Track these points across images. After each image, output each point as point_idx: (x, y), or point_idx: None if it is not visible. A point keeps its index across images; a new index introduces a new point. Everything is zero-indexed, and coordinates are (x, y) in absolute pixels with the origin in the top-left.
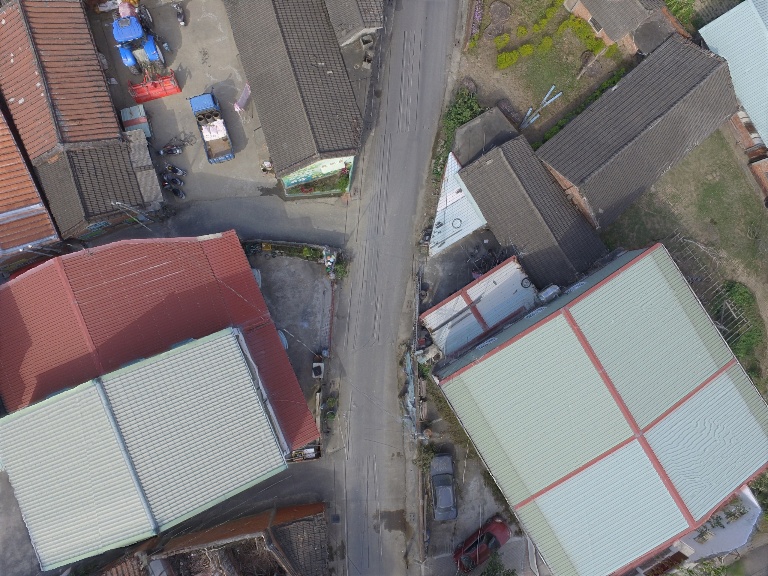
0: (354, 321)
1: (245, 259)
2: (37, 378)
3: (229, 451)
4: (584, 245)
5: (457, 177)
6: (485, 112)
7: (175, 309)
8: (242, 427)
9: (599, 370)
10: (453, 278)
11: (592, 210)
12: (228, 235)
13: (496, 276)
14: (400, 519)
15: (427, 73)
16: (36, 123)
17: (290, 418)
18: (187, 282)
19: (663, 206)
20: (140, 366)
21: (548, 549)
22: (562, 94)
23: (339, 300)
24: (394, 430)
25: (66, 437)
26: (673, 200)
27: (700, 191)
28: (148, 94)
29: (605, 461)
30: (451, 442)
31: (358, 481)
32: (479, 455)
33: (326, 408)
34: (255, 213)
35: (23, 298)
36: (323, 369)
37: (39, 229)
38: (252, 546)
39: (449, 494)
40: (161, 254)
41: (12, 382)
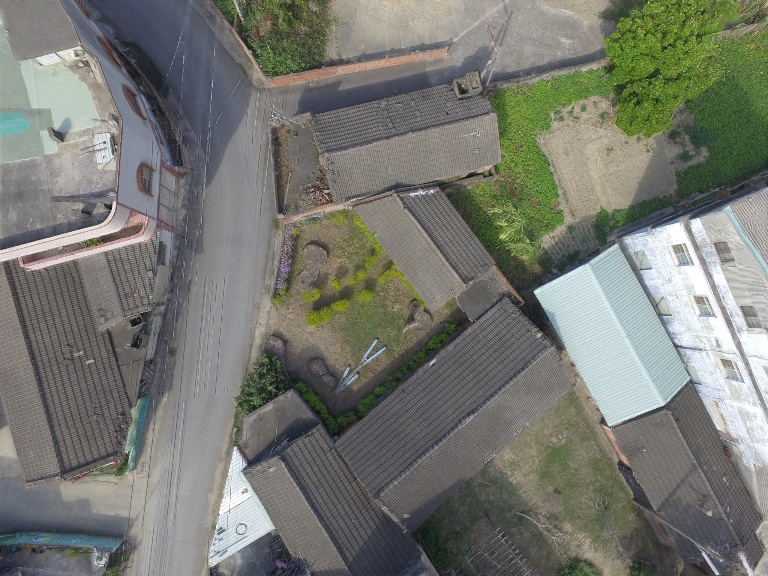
0: None
1: None
2: None
3: None
4: (387, 555)
5: (242, 476)
6: (278, 397)
7: None
8: None
9: None
10: (254, 566)
11: (395, 517)
12: None
13: None
14: None
15: (230, 327)
16: None
17: None
18: None
19: (499, 475)
20: None
21: None
22: (386, 349)
23: None
24: None
25: None
26: (511, 468)
27: (543, 456)
28: None
29: None
30: None
31: None
32: None
33: None
34: (24, 497)
35: None
36: None
37: None
38: None
39: None
40: None
41: None
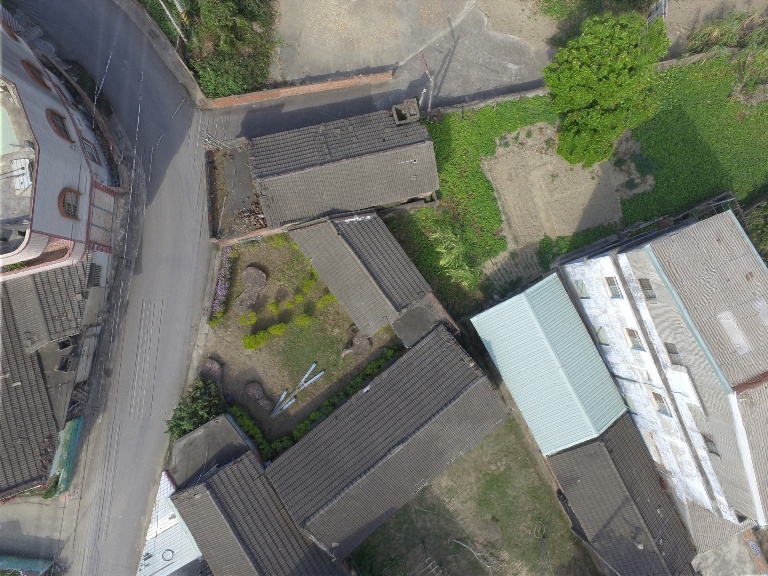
0: None
1: None
2: None
3: None
4: None
5: (169, 502)
6: (209, 422)
7: None
8: None
9: None
10: None
11: (323, 545)
12: None
13: None
14: None
15: (167, 348)
16: None
17: None
18: None
19: (437, 502)
20: None
21: None
22: (324, 373)
23: None
24: None
25: None
26: (449, 495)
27: (481, 483)
28: None
29: None
30: None
31: None
32: None
33: None
34: None
35: None
36: None
37: None
38: None
39: None
40: None
41: None
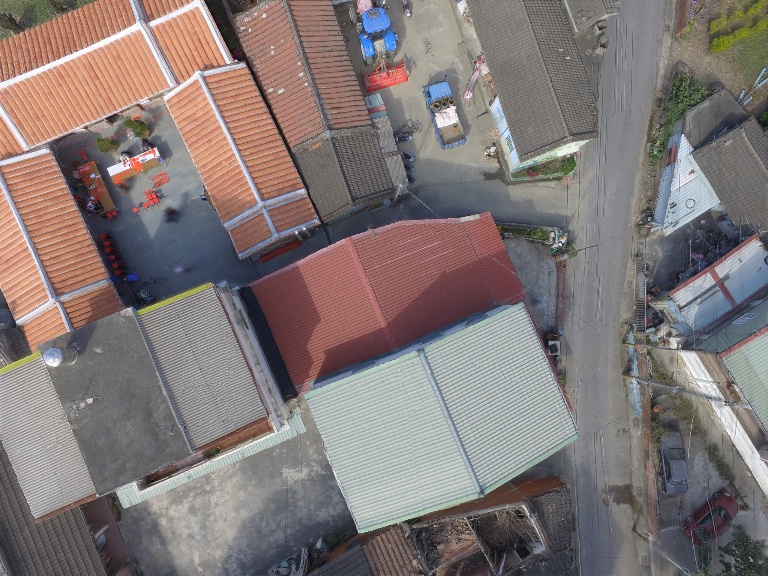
0: (578, 301)
1: (501, 239)
2: (325, 353)
3: (531, 420)
4: None
5: (690, 158)
6: (714, 94)
7: (448, 287)
8: (540, 397)
9: None
10: (672, 258)
11: None
12: (485, 216)
13: (741, 254)
14: (627, 493)
15: (640, 58)
16: (298, 112)
17: None
18: (455, 261)
19: None
20: (453, 338)
21: None
22: None
23: (563, 280)
24: (619, 406)
25: (386, 406)
26: None
27: None
28: (380, 83)
29: None
30: (675, 418)
31: (586, 456)
32: (760, 425)
33: None
34: (480, 197)
35: (313, 277)
36: (560, 346)
37: (304, 213)
38: (492, 517)
39: (683, 468)
40: (432, 234)
41: (299, 357)
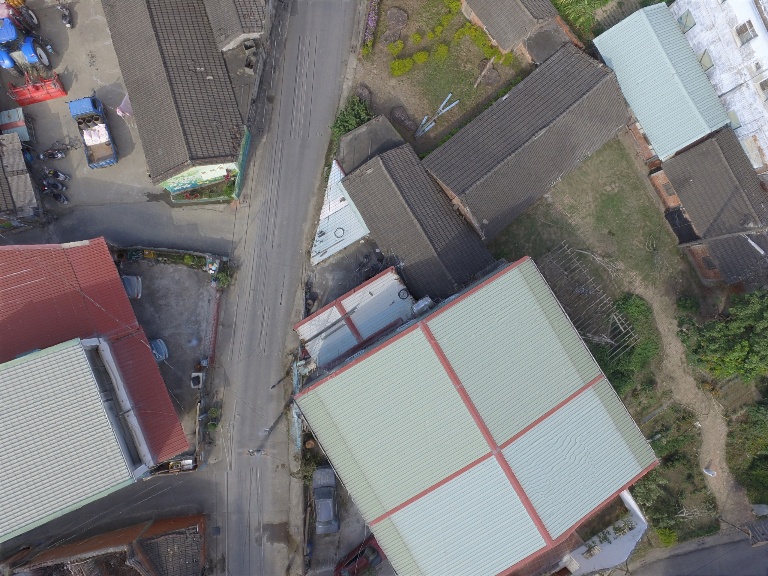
0: (240, 330)
1: (113, 267)
2: None
3: (69, 465)
4: (468, 256)
5: (340, 186)
6: (371, 120)
7: (33, 318)
8: (85, 440)
9: (456, 385)
10: (343, 287)
11: (476, 221)
12: (96, 242)
13: (372, 287)
14: (283, 532)
15: (321, 79)
16: None
17: (157, 430)
18: (48, 290)
19: (560, 217)
20: None
21: (403, 567)
22: (459, 102)
23: (225, 309)
24: (279, 441)
25: None
26: (570, 211)
27: (598, 202)
28: (30, 97)
29: (462, 478)
30: None
31: (240, 493)
32: None
33: (208, 418)
34: (140, 219)
35: None
36: (201, 379)
37: None
38: None
39: (329, 507)
40: (20, 261)
41: None
